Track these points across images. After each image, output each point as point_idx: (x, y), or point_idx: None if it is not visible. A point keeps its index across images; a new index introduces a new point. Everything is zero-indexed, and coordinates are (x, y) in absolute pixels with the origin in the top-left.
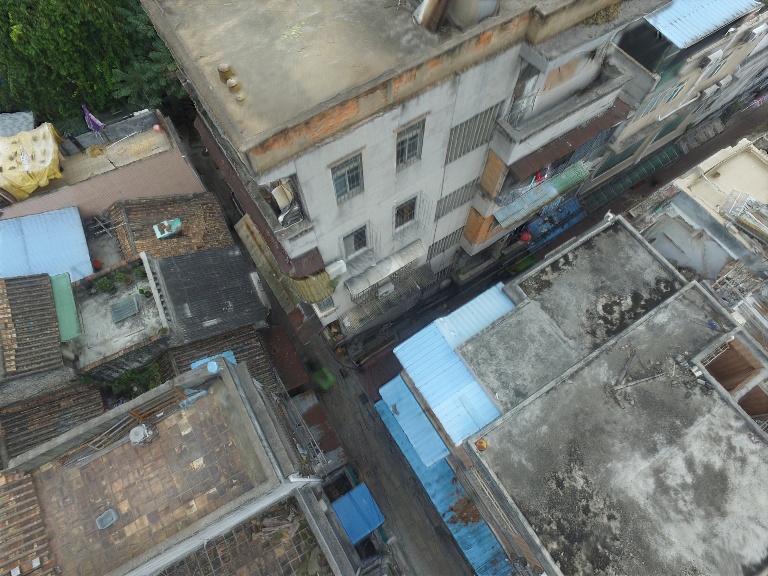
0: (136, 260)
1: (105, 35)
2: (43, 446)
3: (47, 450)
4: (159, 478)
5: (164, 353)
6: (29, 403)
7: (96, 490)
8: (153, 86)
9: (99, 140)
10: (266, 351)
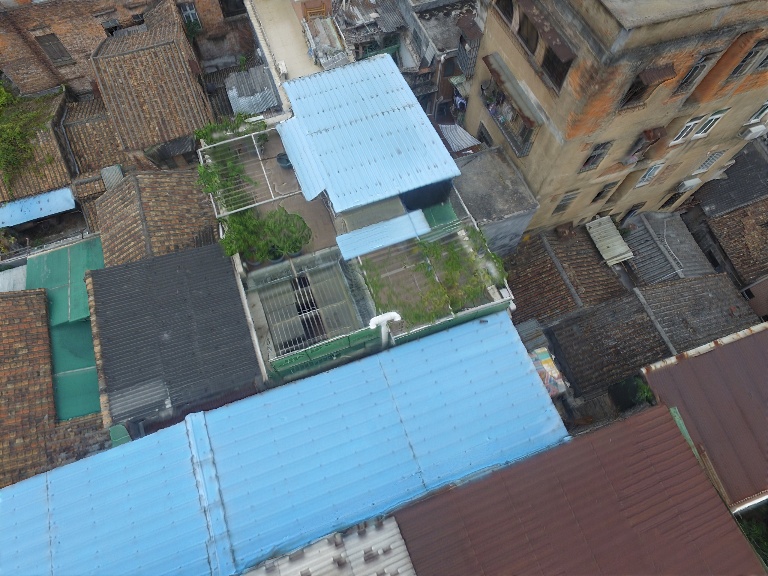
0: None
1: None
2: None
3: None
4: None
5: None
6: None
7: None
8: None
9: None
10: None
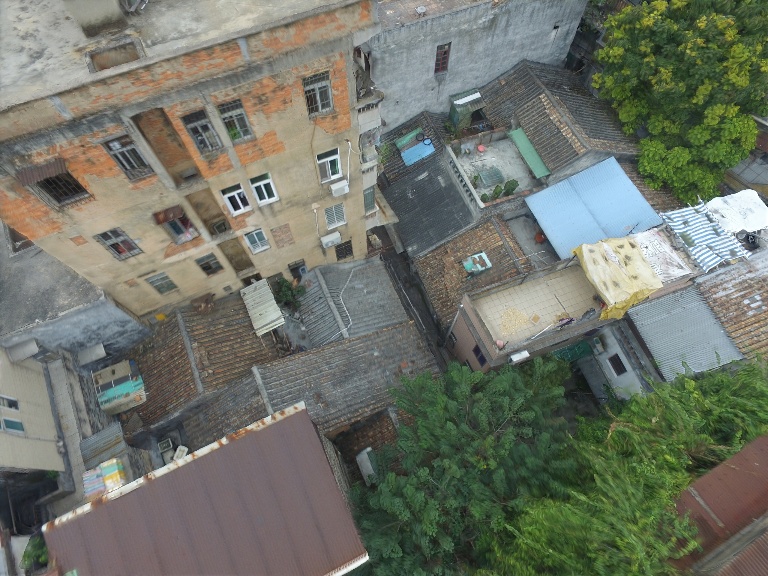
0: None
1: None
2: (475, 4)
3: (472, 3)
4: (411, 7)
5: None
6: None
7: (446, 5)
8: None
9: None
10: (385, 185)
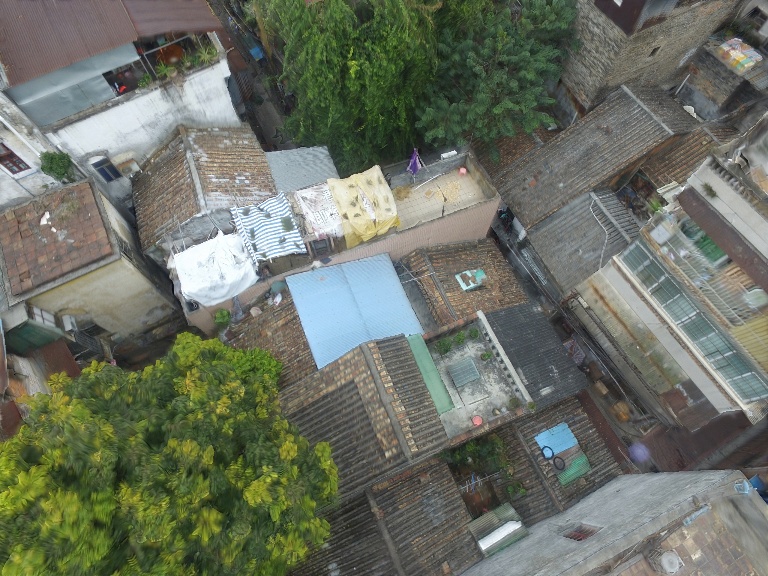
0: (472, 319)
1: (417, 71)
2: (573, 571)
3: None
4: None
5: (505, 423)
6: (394, 478)
7: None
8: (466, 127)
9: (406, 182)
10: None
